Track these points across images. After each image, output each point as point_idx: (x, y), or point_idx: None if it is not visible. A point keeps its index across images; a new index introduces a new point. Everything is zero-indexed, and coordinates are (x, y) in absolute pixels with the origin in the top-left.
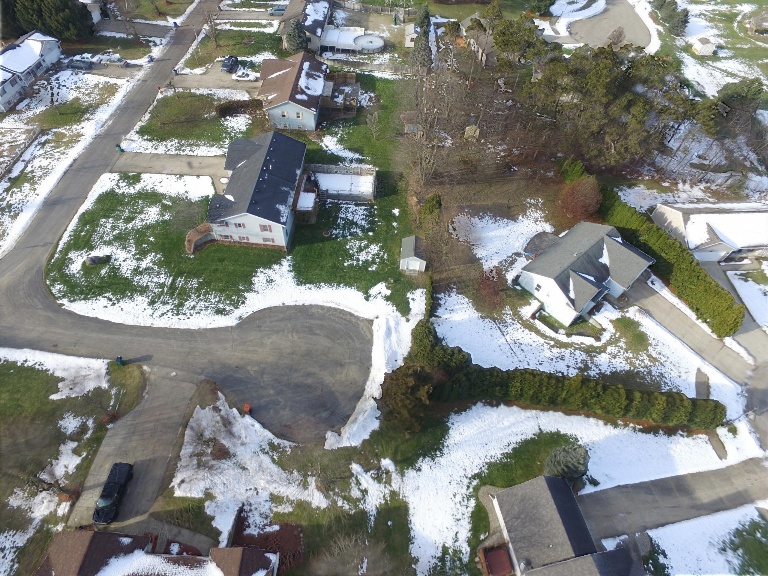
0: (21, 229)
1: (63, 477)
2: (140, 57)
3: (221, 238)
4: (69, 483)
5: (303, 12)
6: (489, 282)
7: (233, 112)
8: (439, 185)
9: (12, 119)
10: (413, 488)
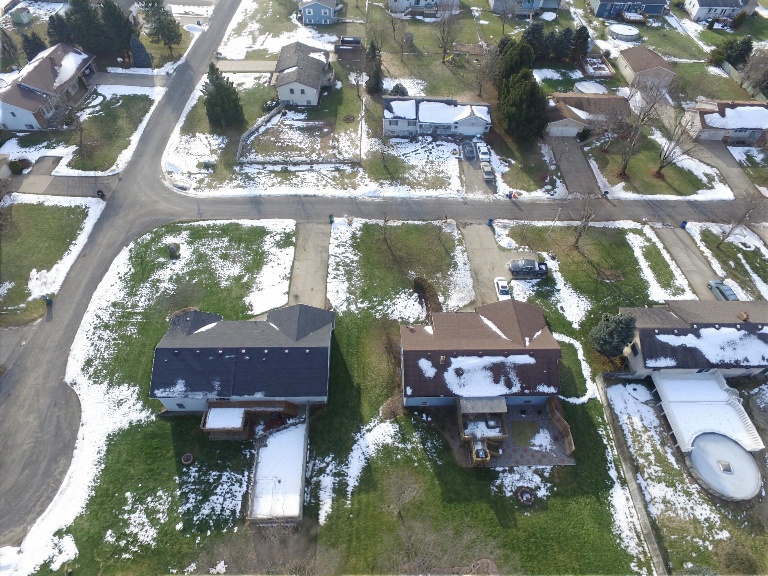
0: (221, 195)
1: None
2: (514, 186)
3: None
4: None
5: (696, 325)
6: None
7: (426, 297)
8: None
9: (374, 142)
10: None
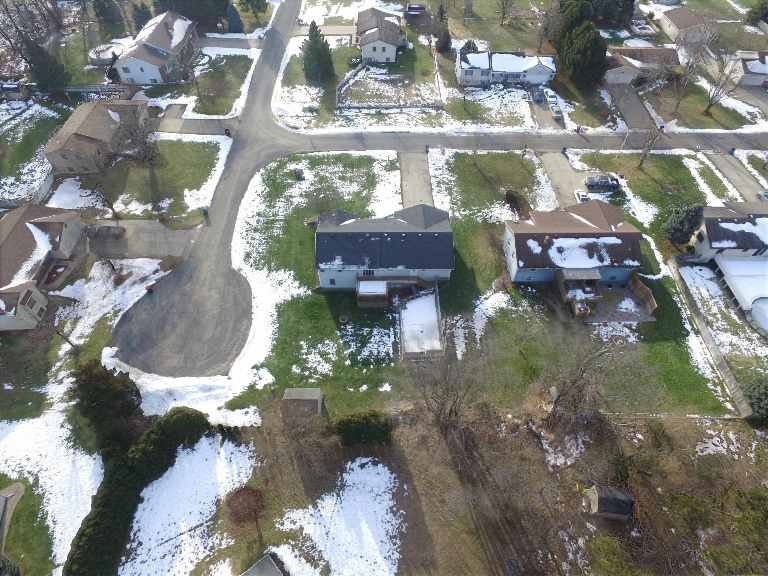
0: (328, 132)
1: (129, 210)
2: (580, 123)
3: None
4: (124, 214)
5: (752, 215)
6: (235, 494)
7: (517, 206)
8: (446, 442)
9: (451, 91)
10: (48, 421)
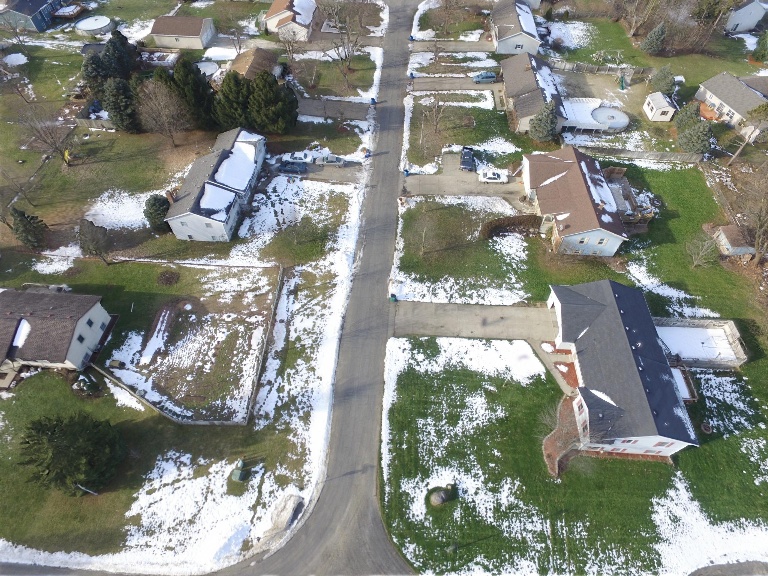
0: (324, 442)
1: None
2: (353, 150)
3: (586, 448)
4: None
5: (538, 86)
6: None
7: (500, 230)
8: None
9: (240, 252)
10: None
